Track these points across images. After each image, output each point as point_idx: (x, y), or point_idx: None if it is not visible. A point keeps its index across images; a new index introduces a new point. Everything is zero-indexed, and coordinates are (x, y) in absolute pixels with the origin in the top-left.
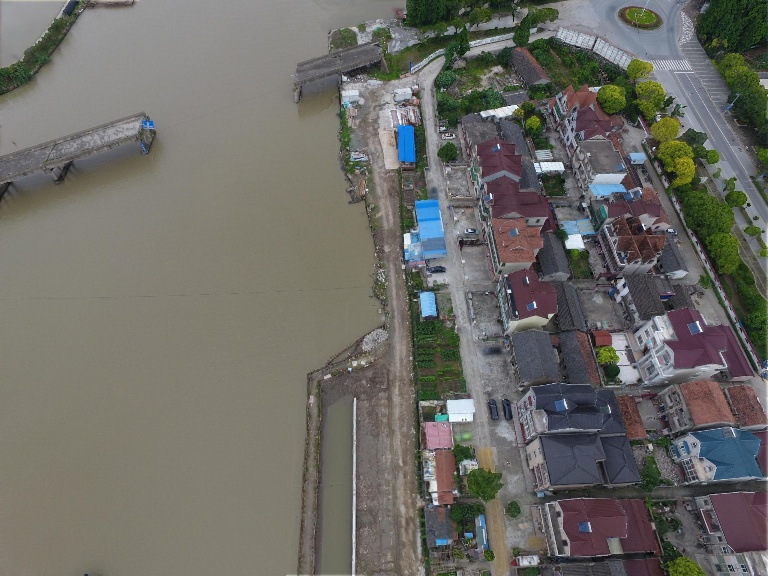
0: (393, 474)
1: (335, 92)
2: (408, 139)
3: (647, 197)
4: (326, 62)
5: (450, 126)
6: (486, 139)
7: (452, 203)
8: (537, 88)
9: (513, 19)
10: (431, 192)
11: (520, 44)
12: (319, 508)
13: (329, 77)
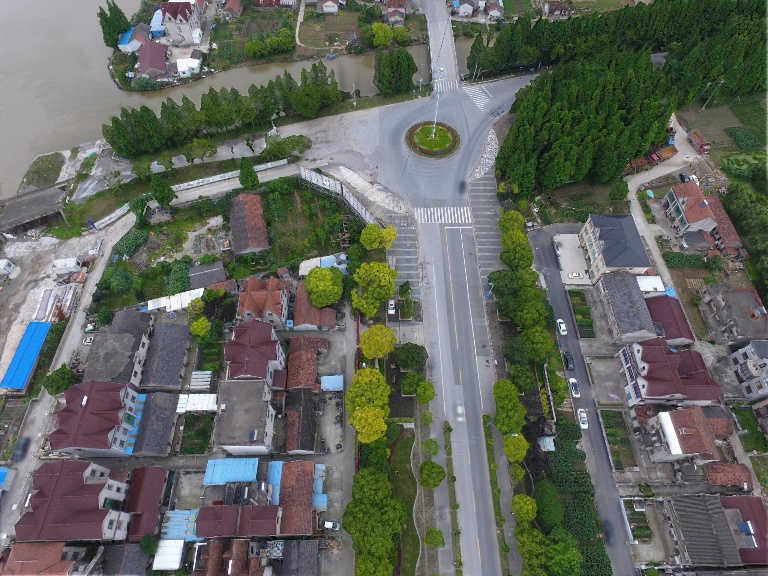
0: None
1: None
2: (32, 347)
3: (291, 480)
4: None
5: (102, 323)
6: (109, 365)
7: None
8: (245, 258)
9: (251, 149)
10: (21, 444)
11: None
12: None
13: None
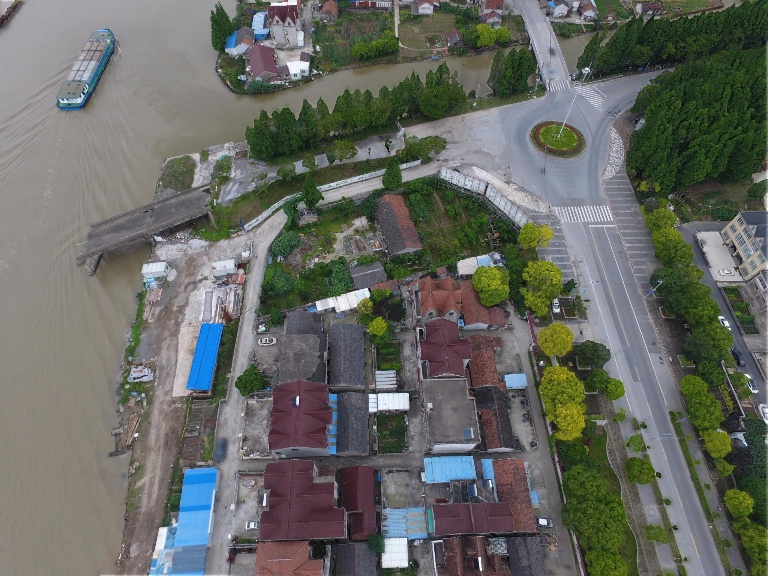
0: None
1: (145, 257)
2: (210, 348)
3: (507, 477)
4: (131, 220)
5: (273, 324)
6: (300, 365)
7: (239, 471)
8: (401, 259)
9: (388, 151)
10: (219, 445)
11: (391, 188)
12: None
13: (133, 242)
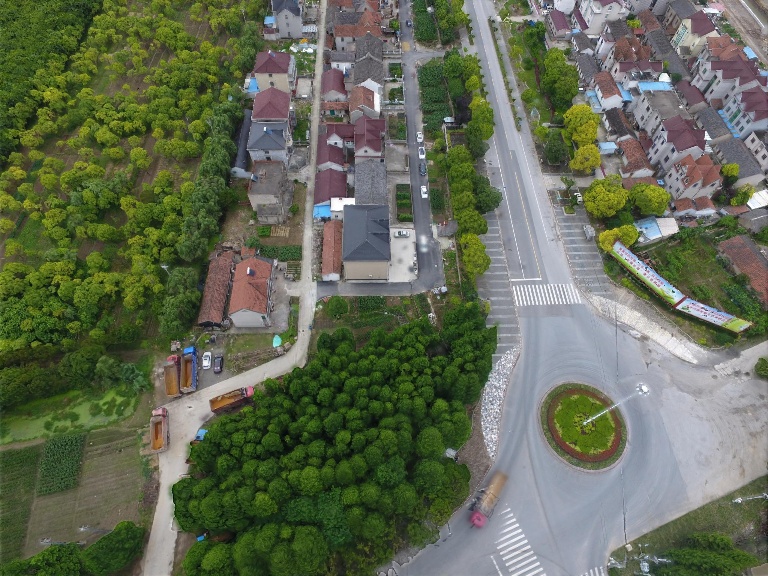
0: (727, 6)
1: None
2: None
3: None
4: None
5: None
6: None
7: None
8: None
9: None
10: None
11: None
12: (753, 3)
13: None
